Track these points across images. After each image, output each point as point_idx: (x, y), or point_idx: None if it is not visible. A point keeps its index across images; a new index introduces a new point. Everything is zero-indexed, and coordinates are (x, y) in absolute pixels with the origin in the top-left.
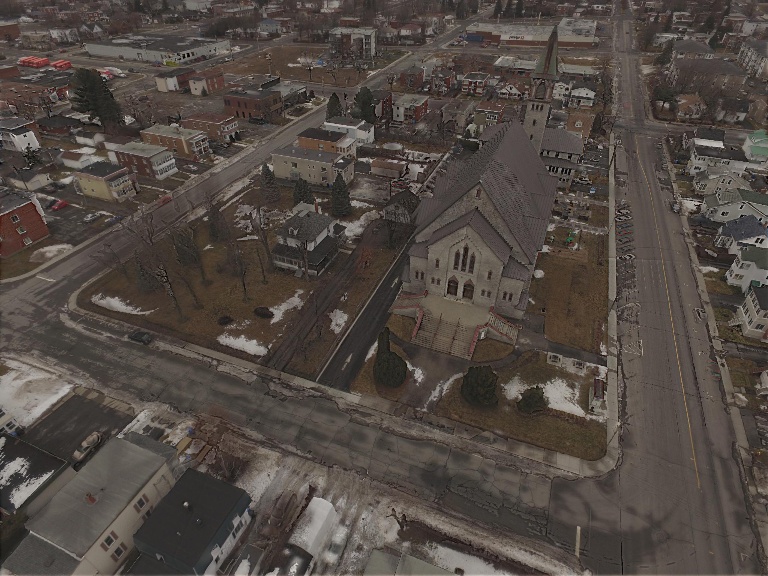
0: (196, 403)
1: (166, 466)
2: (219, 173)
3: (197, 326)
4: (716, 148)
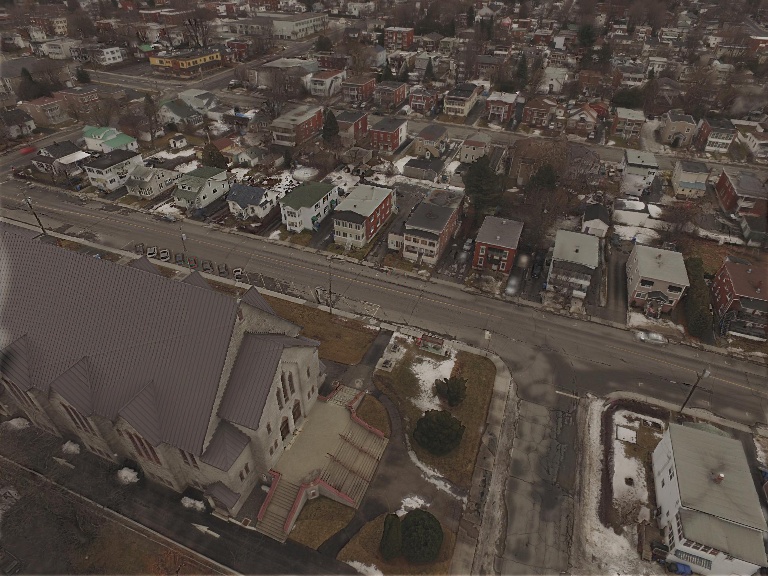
0: None
1: None
2: None
3: None
4: (85, 158)
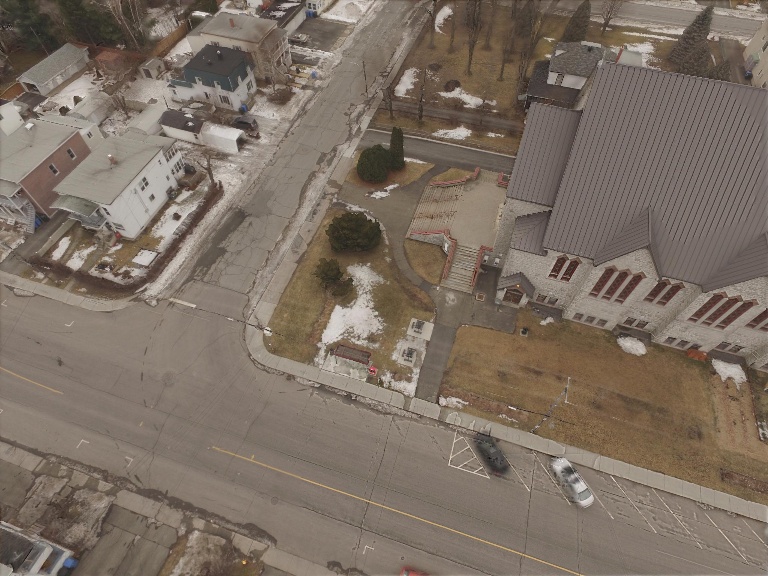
0: (341, 73)
1: (258, 49)
2: (715, 15)
3: (425, 55)
4: None
